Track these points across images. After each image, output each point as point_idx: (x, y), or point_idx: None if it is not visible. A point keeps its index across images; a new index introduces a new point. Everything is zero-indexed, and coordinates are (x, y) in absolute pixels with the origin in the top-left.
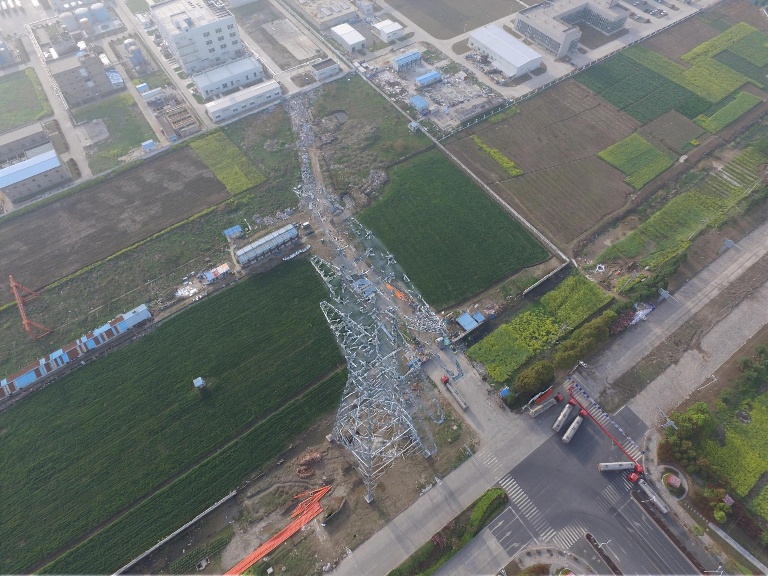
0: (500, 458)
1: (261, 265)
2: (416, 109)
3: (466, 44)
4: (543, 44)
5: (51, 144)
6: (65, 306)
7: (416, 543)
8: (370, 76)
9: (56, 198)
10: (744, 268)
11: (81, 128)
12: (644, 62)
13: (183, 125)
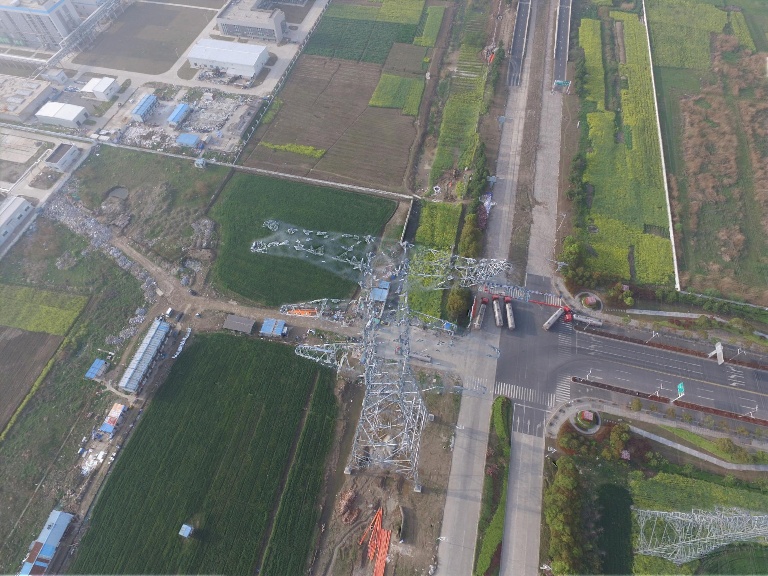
0: (482, 376)
1: (155, 379)
2: (190, 147)
3: (189, 67)
4: (258, 36)
5: None
6: None
7: (478, 488)
8: (118, 140)
9: None
10: (521, 131)
11: None
12: (347, 16)
13: None
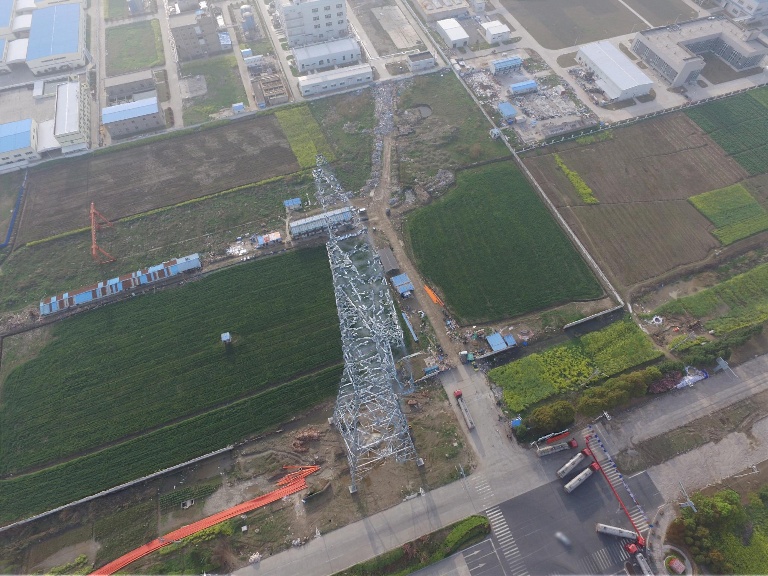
0: (493, 487)
1: (310, 240)
2: (502, 116)
3: (573, 57)
4: (658, 70)
5: (156, 91)
6: (131, 240)
7: (386, 545)
8: (464, 75)
9: (148, 141)
10: None
11: (185, 81)
12: None
13: (273, 94)
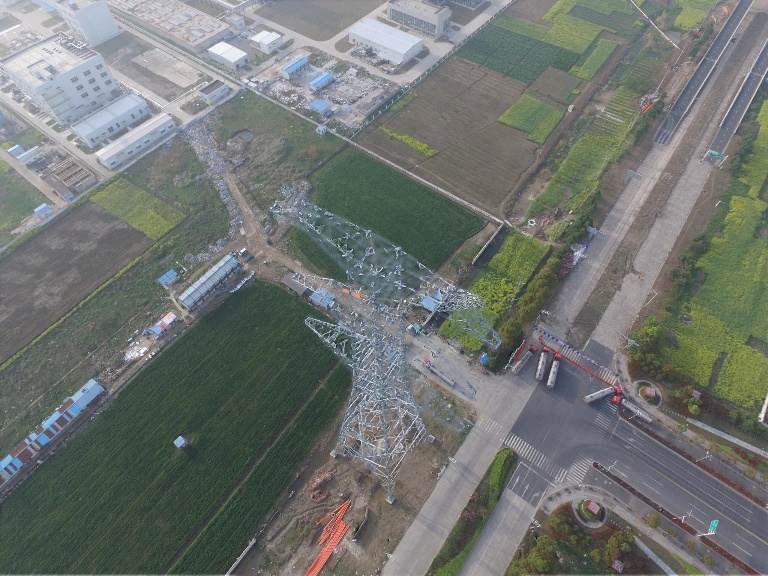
0: (498, 420)
1: (209, 304)
2: (319, 113)
3: (347, 41)
4: (419, 28)
5: None
6: None
7: (448, 526)
8: (263, 90)
9: None
10: (648, 192)
11: None
12: (512, 29)
13: (76, 180)
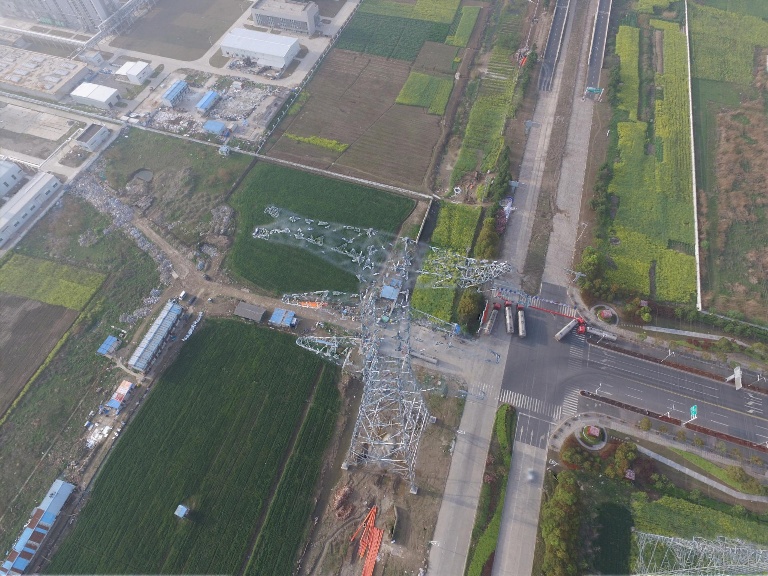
0: (488, 382)
1: (163, 360)
2: (215, 134)
3: (221, 55)
4: (290, 28)
5: None
6: None
7: (474, 495)
8: (147, 124)
9: None
10: (548, 137)
11: None
12: (380, 12)
13: None
